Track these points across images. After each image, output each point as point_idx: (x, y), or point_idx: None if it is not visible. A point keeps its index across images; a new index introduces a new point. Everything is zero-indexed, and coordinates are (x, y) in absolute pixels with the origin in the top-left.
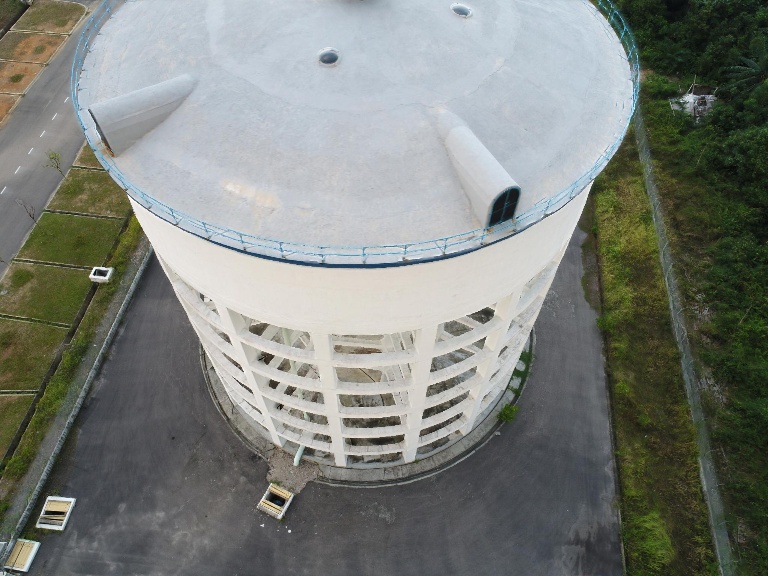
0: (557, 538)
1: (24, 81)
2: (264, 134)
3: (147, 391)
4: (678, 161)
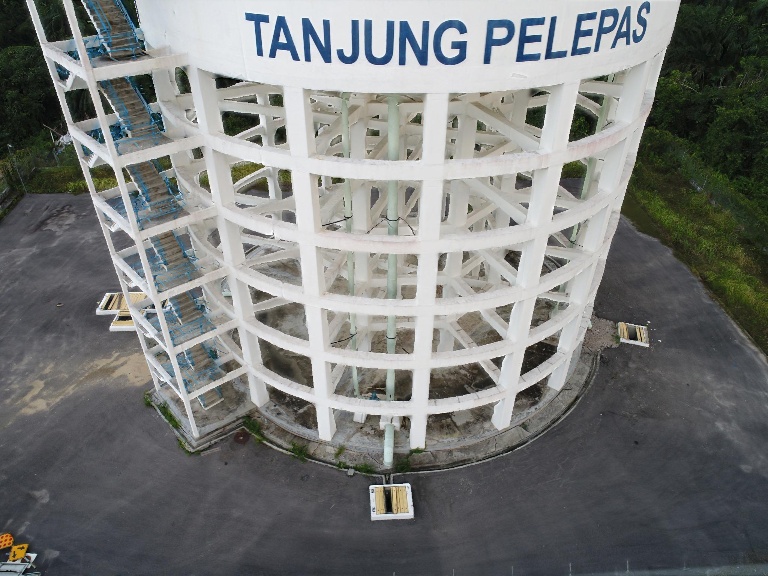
0: None
1: None
2: None
3: (598, 500)
4: None
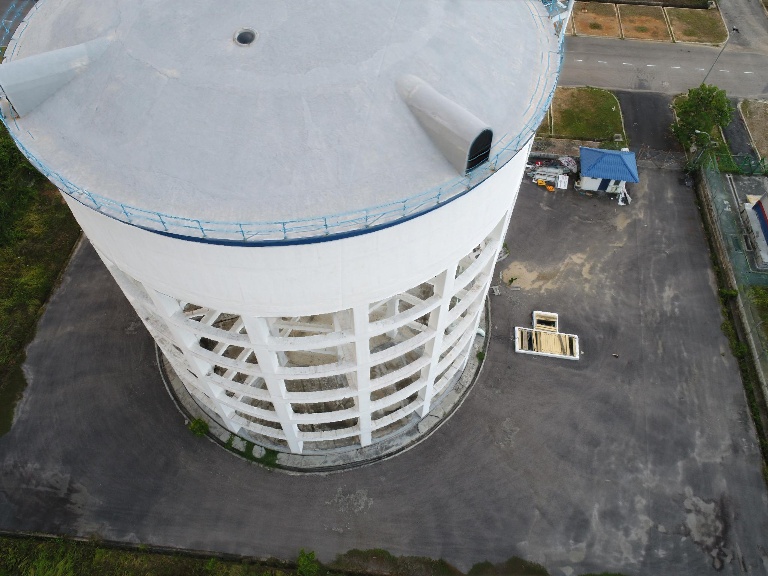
0: (78, 471)
1: (594, 31)
2: None
3: None
4: None
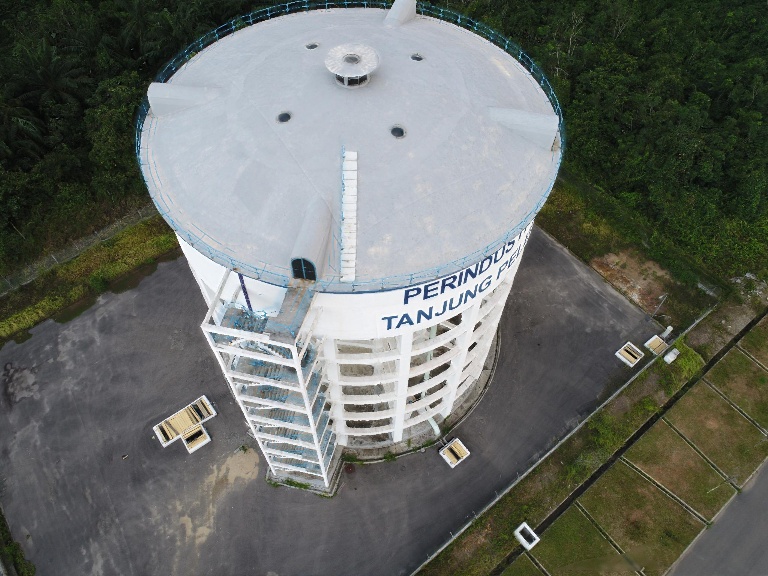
0: None
1: None
2: (478, 66)
3: (540, 389)
4: (16, 257)
